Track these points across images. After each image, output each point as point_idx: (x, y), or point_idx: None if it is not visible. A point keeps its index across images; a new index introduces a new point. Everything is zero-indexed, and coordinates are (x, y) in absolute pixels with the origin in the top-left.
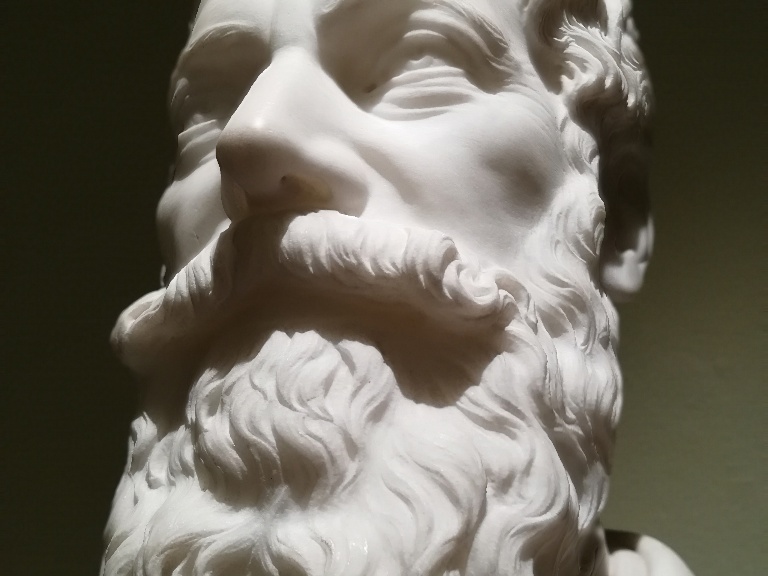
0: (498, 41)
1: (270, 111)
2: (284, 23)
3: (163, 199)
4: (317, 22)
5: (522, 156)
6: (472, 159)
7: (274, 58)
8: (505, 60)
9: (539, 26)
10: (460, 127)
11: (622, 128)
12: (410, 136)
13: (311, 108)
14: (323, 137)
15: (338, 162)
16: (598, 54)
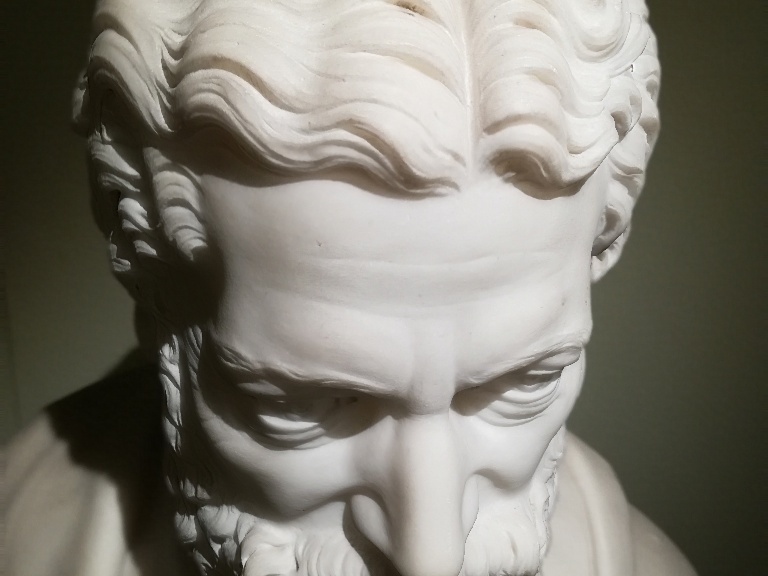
0: None
1: (454, 546)
2: (430, 395)
3: (229, 442)
4: (460, 385)
5: None
6: None
7: (414, 422)
8: None
9: None
10: (547, 428)
11: None
12: (513, 450)
13: None
14: None
15: None
16: None
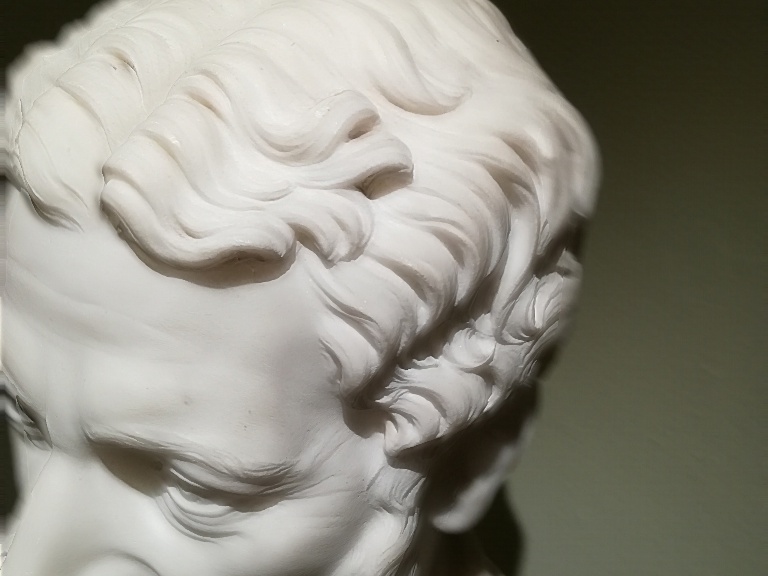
0: (274, 475)
1: None
2: (53, 426)
3: None
4: None
5: (290, 573)
6: None
7: None
8: (287, 479)
9: (351, 404)
10: (223, 563)
11: None
12: (177, 560)
13: (76, 550)
14: (92, 566)
15: None
16: (437, 401)
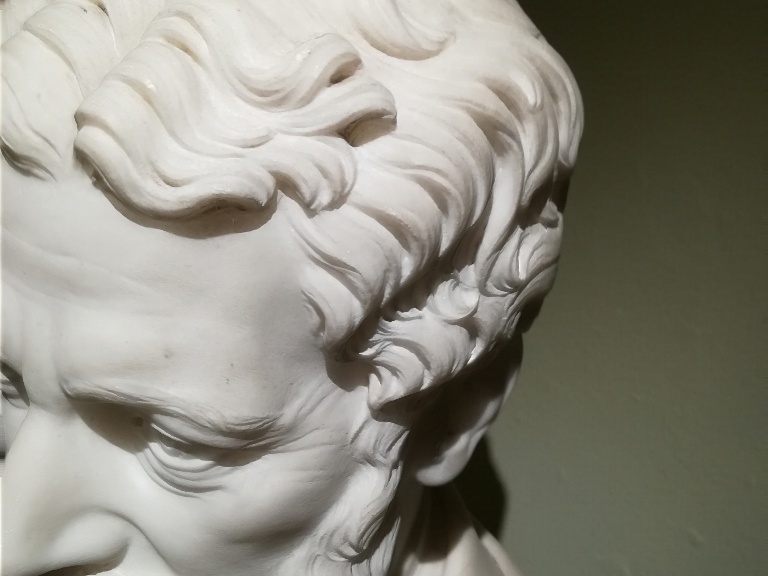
0: (258, 428)
1: (7, 547)
2: (30, 382)
3: None
4: None
5: (275, 527)
6: (218, 542)
7: None
8: (270, 433)
9: (335, 357)
10: (206, 518)
11: (464, 368)
12: (160, 516)
13: (56, 507)
14: (73, 523)
15: (86, 554)
16: (421, 353)
